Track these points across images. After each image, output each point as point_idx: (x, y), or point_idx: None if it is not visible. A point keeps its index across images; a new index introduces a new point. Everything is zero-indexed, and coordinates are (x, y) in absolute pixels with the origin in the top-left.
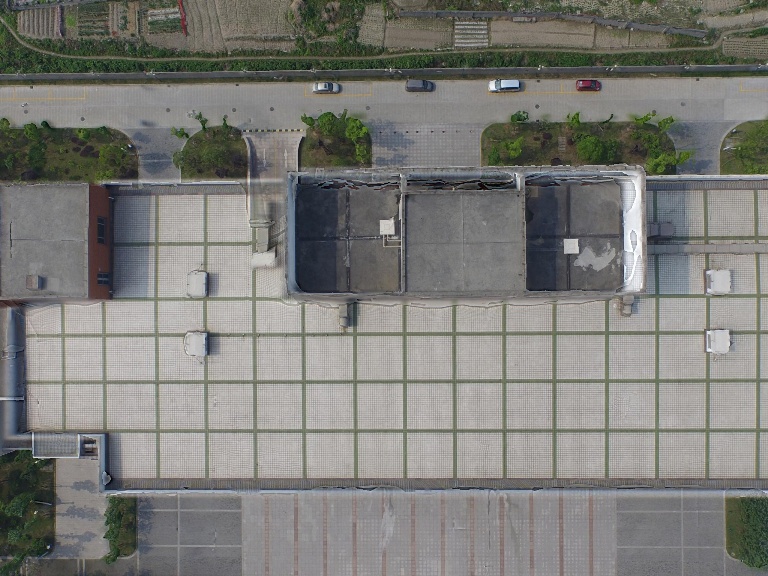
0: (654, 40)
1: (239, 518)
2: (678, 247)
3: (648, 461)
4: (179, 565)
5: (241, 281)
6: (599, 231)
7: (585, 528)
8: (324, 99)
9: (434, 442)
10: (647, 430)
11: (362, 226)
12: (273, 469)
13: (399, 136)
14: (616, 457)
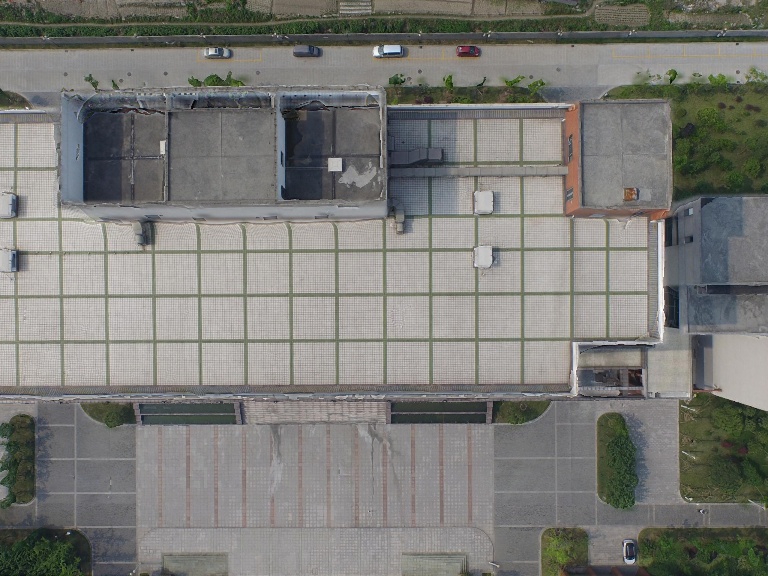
0: (529, 8)
1: (133, 466)
2: (445, 170)
3: (423, 368)
4: (76, 512)
5: (48, 203)
6: (362, 151)
7: (464, 474)
8: (216, 64)
9: (227, 352)
10: (422, 340)
11: (146, 147)
12: (78, 377)
13: (288, 100)
14: (393, 365)
